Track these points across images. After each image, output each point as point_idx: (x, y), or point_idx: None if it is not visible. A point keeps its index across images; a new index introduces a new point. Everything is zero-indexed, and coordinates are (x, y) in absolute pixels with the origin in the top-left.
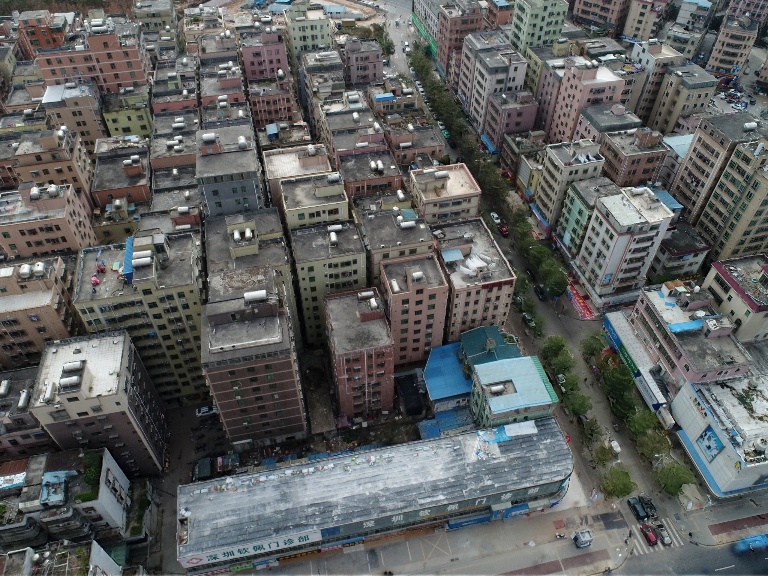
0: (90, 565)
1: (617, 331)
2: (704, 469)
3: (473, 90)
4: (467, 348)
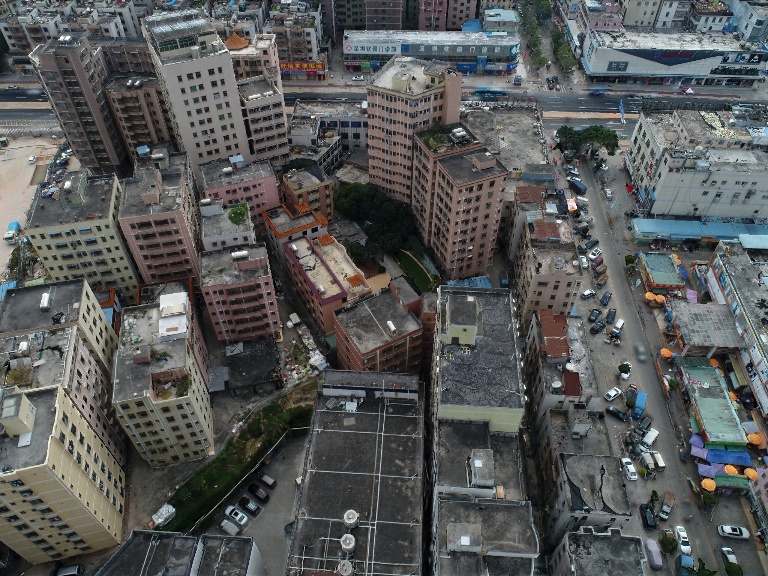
0: None
1: (569, 25)
2: (587, 67)
3: None
4: None
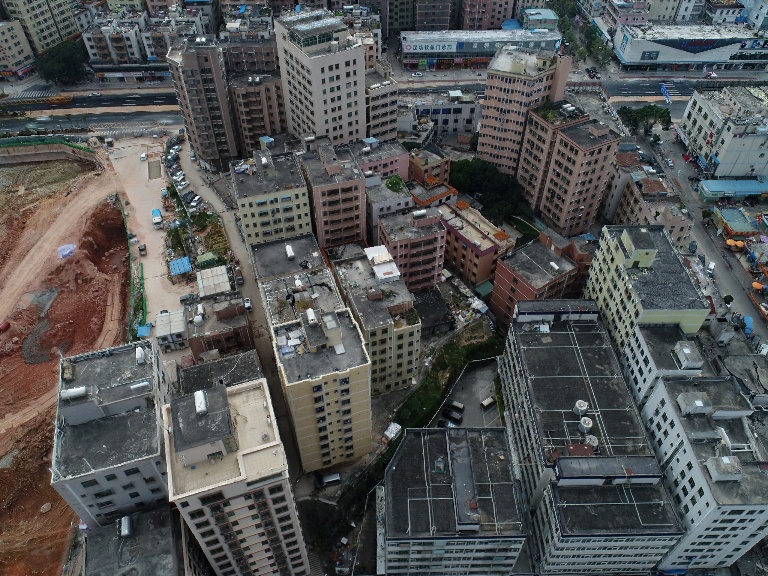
0: None
1: (596, 22)
2: (621, 57)
3: None
4: (522, 11)
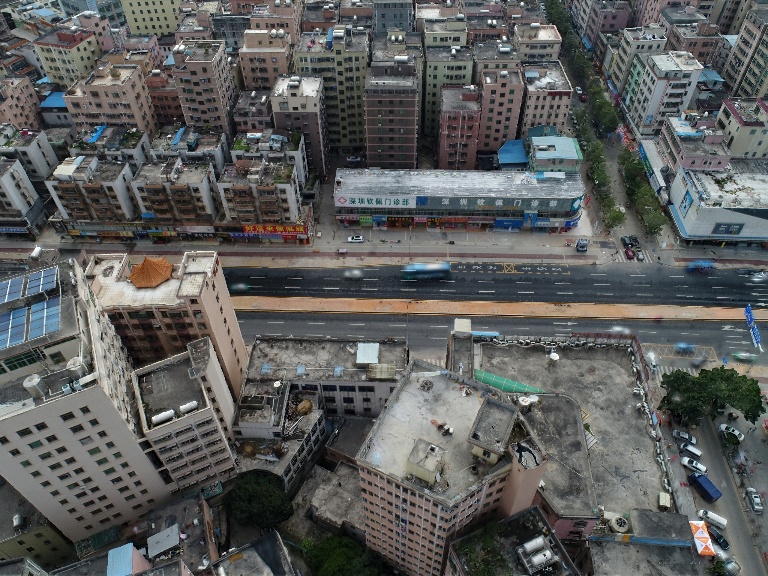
0: (293, 171)
1: (645, 149)
2: (680, 224)
3: (583, 2)
4: (530, 134)
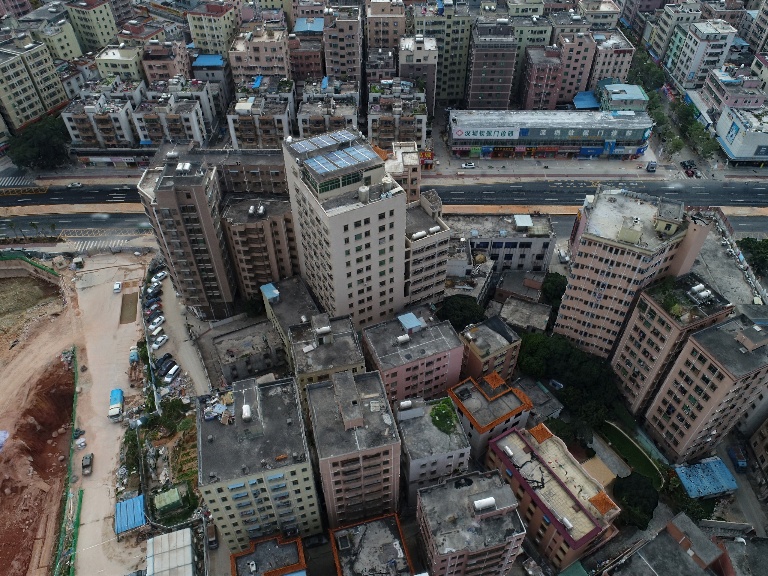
0: None
1: (691, 98)
2: (728, 150)
3: None
4: (601, 85)
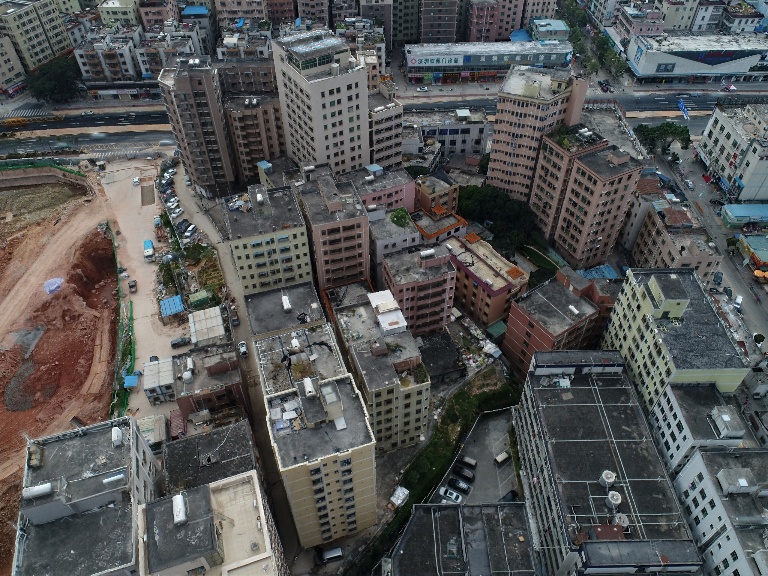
0: None
1: (608, 32)
2: (635, 70)
3: None
4: (531, 22)
